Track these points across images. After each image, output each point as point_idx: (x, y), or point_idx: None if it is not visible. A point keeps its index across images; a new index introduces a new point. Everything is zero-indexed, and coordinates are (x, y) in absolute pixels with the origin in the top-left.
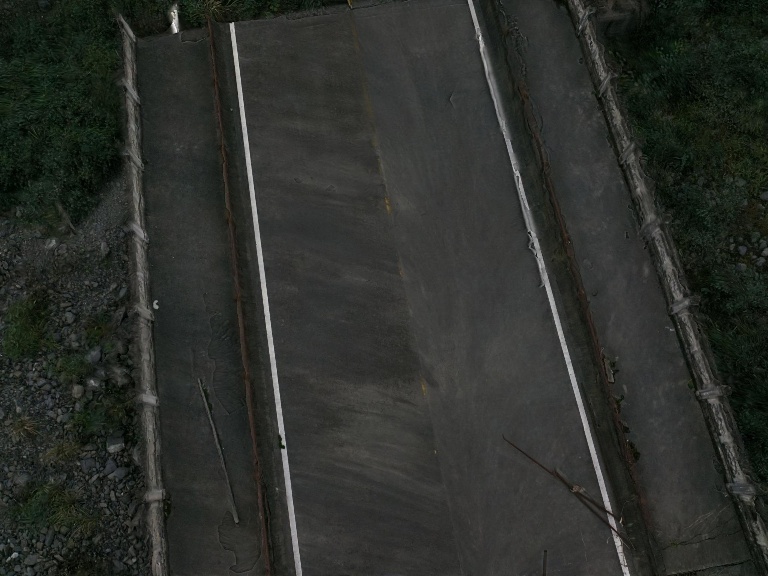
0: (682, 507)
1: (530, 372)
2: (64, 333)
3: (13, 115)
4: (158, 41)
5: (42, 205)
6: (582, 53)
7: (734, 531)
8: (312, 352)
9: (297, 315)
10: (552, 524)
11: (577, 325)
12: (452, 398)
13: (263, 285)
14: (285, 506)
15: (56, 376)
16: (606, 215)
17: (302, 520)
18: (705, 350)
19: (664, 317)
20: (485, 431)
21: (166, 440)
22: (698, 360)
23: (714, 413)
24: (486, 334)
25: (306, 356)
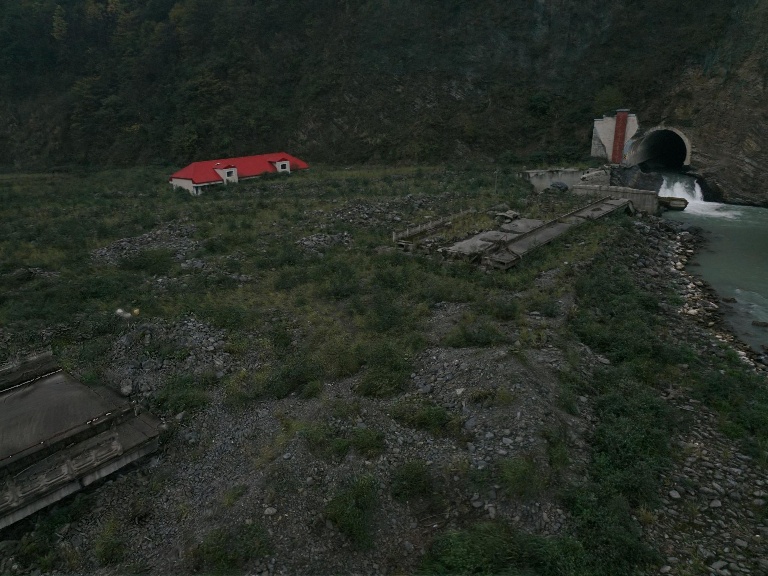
0: None
1: None
2: None
3: None
4: None
5: None
6: None
7: None
8: None
9: None
10: (44, 386)
11: None
12: None
13: None
14: None
15: None
16: None
17: None
18: None
19: None
20: None
21: None
22: None
23: None
24: None
25: None
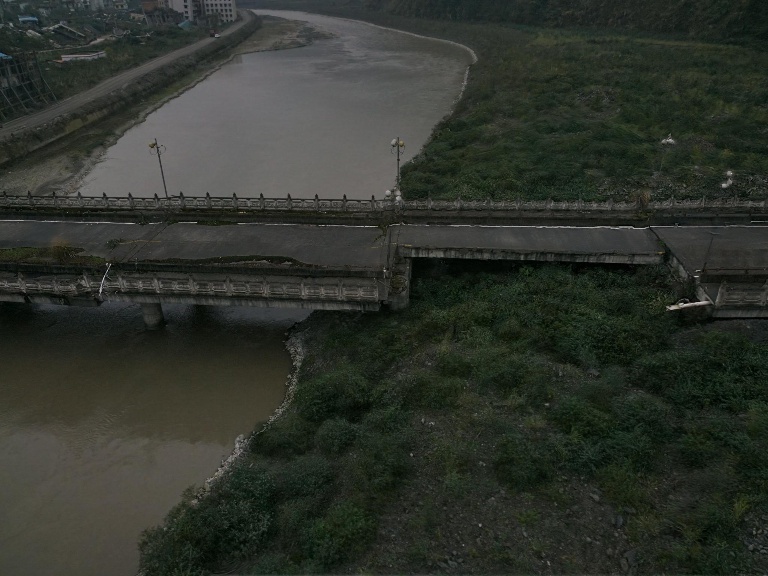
0: None
1: None
2: None
3: (764, 385)
4: (715, 292)
5: None
6: (679, 210)
7: None
8: None
9: None
10: None
11: None
12: None
13: None
14: None
15: None
16: (761, 211)
17: None
18: None
19: None
20: None
21: None
22: None
23: None
24: None
25: None
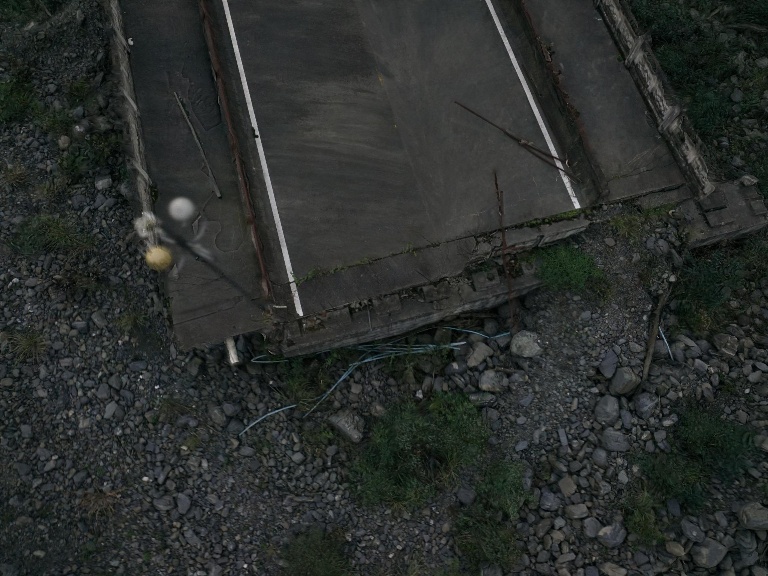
0: (621, 149)
1: (475, 60)
2: (48, 101)
3: None
4: None
5: (19, 0)
6: None
7: (669, 163)
8: (277, 62)
9: (261, 36)
10: (506, 171)
11: (514, 21)
12: (407, 84)
13: (228, 16)
14: (262, 180)
15: (43, 136)
16: None
17: (279, 190)
18: (626, 12)
19: (592, 14)
20: (439, 107)
21: (149, 143)
22: (623, 31)
23: (641, 70)
24: (433, 34)
25: (272, 66)
